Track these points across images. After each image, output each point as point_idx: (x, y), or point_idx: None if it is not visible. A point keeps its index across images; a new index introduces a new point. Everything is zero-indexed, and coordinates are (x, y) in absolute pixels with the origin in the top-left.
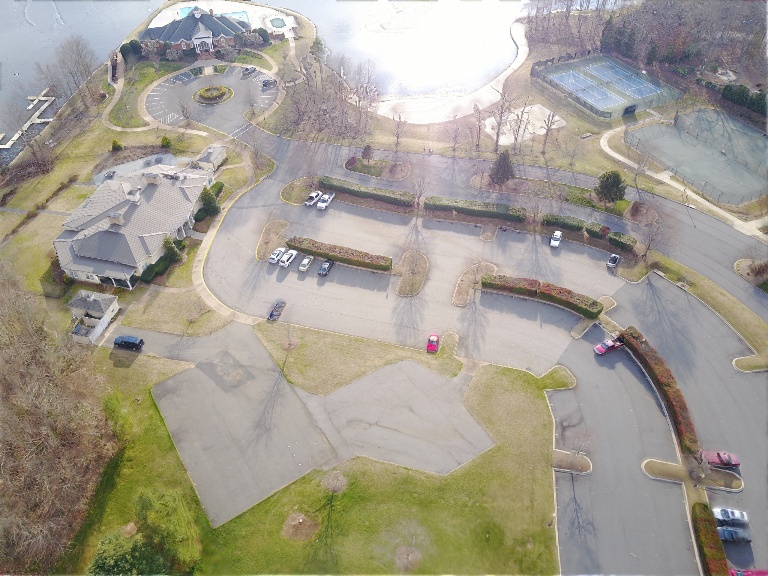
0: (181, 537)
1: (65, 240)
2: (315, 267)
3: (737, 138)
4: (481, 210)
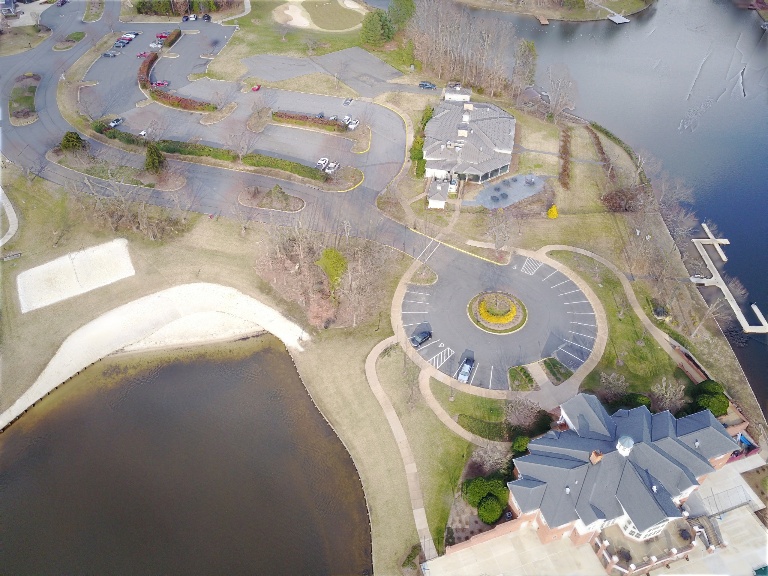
0: None
1: (506, 116)
2: None
3: None
4: None
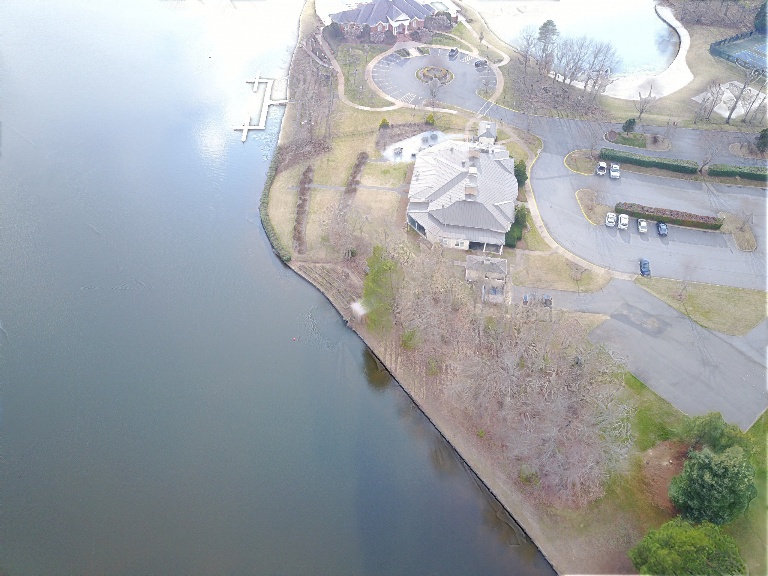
0: (755, 450)
1: (419, 211)
2: (650, 229)
3: None
4: (767, 175)
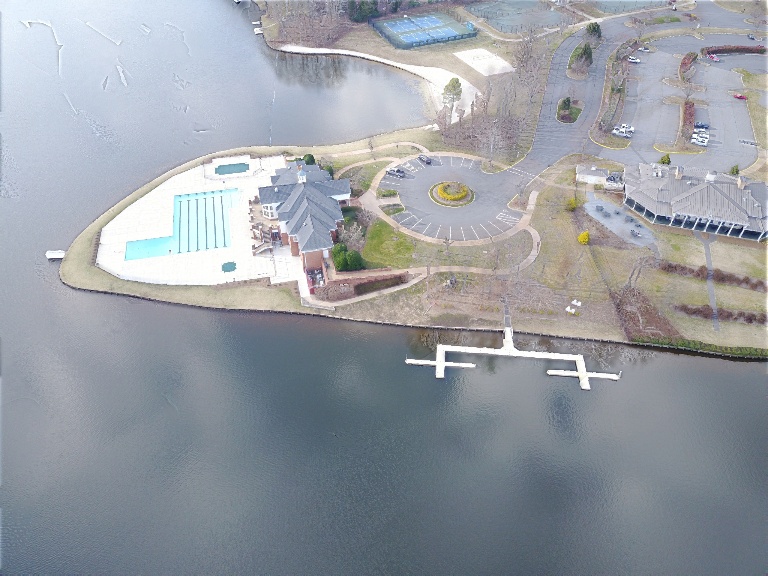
0: None
1: (760, 224)
2: None
3: (500, 8)
4: None
